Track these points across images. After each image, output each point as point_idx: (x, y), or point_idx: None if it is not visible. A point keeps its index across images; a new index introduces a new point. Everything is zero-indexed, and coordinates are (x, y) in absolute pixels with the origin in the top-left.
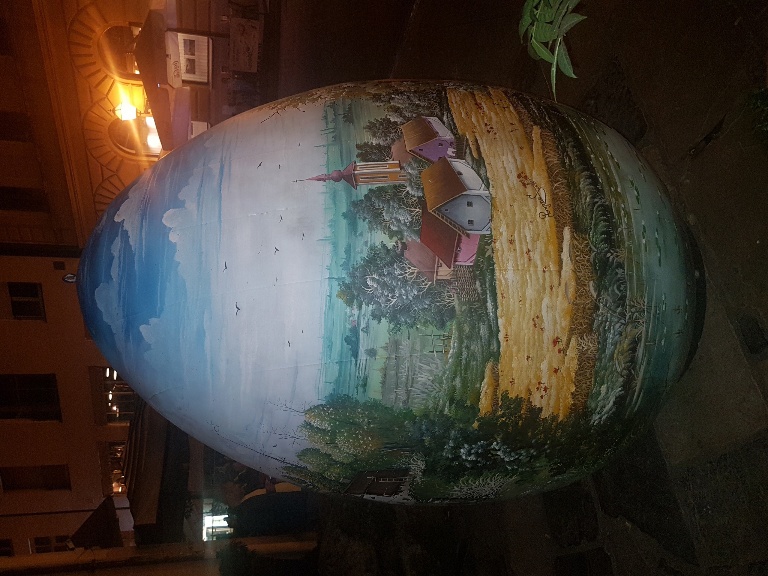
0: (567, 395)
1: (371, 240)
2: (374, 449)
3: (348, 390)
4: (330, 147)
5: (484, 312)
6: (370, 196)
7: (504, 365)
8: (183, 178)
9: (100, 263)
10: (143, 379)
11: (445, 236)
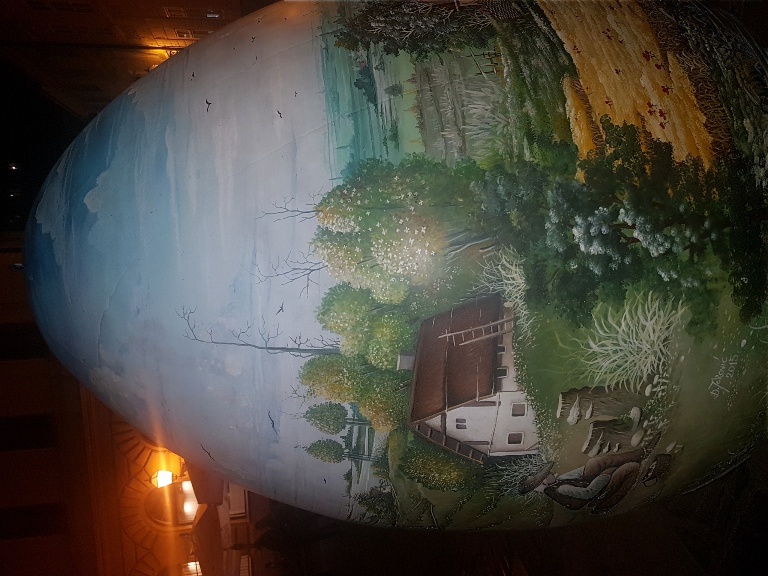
0: (698, 127)
1: None
2: (435, 253)
3: (373, 150)
4: None
5: (534, 26)
6: None
7: (587, 81)
8: None
9: None
10: (88, 291)
11: None
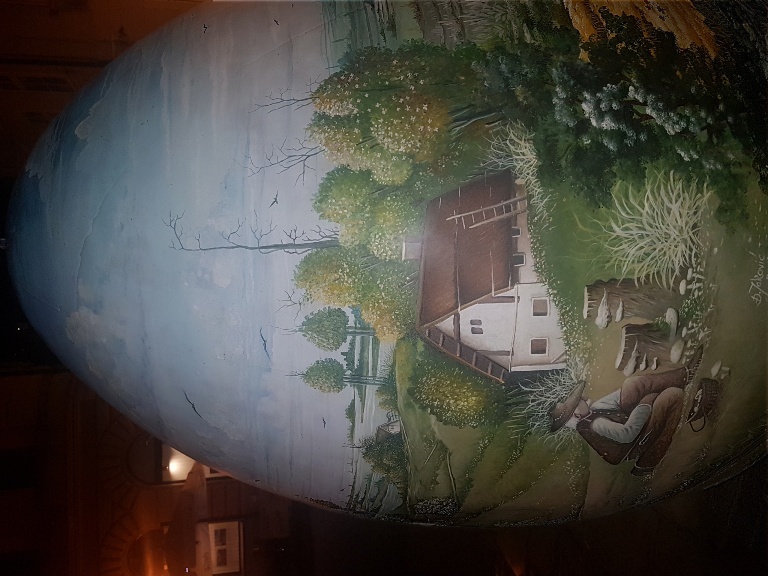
0: (698, 23)
1: None
2: (438, 129)
3: (370, 40)
4: None
5: None
6: None
7: None
8: None
9: None
10: (70, 219)
11: None
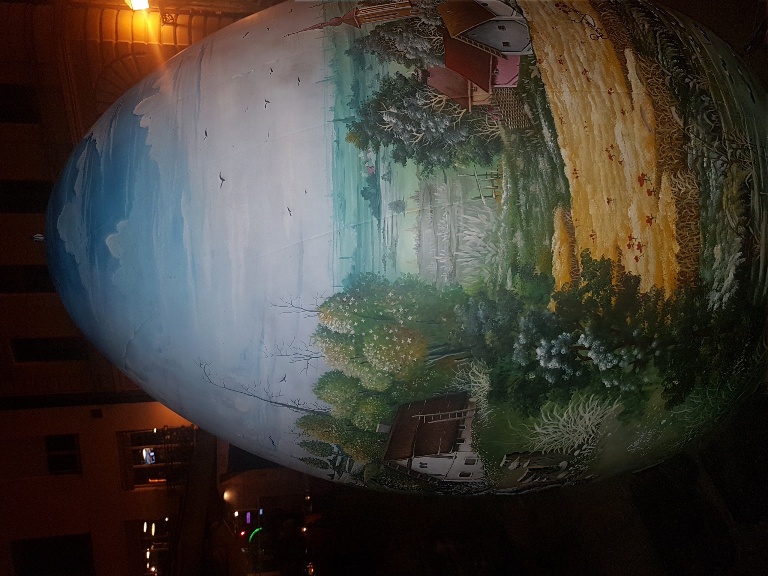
0: (670, 258)
1: (383, 72)
2: (417, 359)
3: (372, 265)
4: (326, 4)
5: (540, 141)
6: (377, 31)
7: (578, 211)
8: (160, 75)
9: (64, 187)
10: (114, 320)
11: (476, 59)
